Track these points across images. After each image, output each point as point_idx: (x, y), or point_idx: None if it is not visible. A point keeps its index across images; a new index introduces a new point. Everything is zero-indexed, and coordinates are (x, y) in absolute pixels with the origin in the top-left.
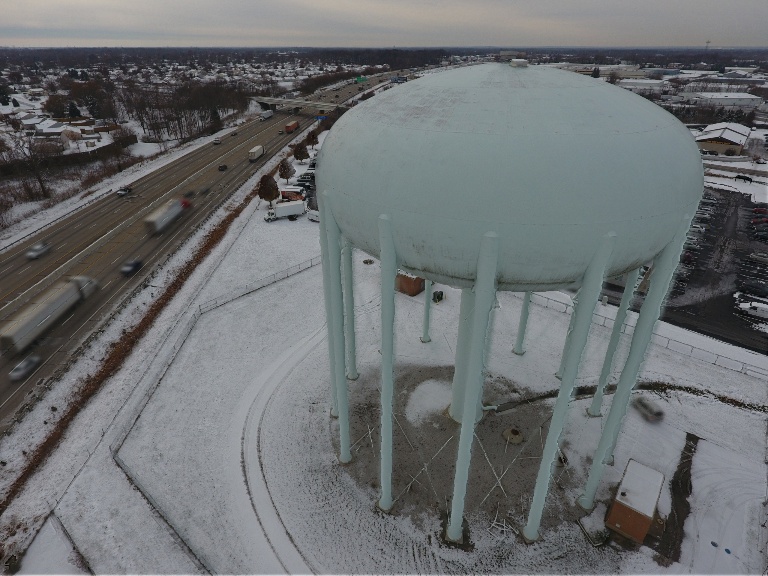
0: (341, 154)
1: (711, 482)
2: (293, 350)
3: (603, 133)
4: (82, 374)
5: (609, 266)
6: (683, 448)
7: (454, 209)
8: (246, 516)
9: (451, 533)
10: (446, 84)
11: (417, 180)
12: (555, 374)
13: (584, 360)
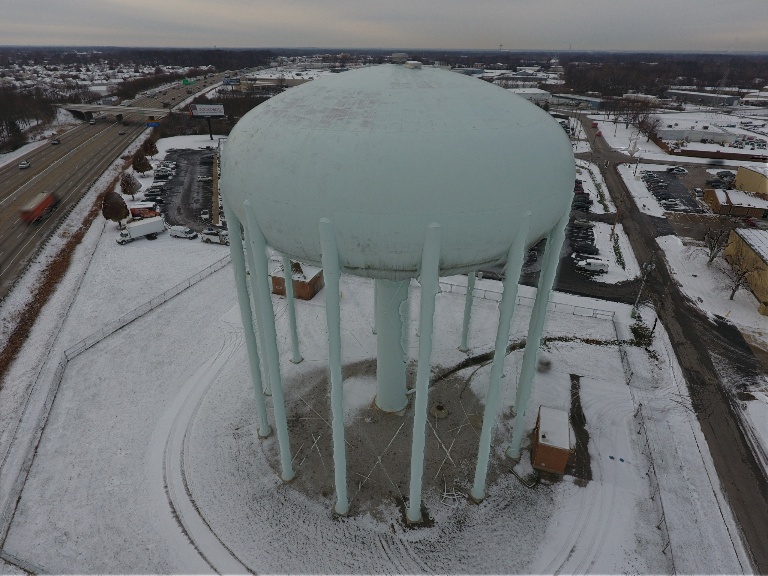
0: (263, 160)
1: (597, 409)
2: (196, 379)
3: (509, 126)
4: None
5: (526, 241)
6: (571, 387)
7: (397, 205)
8: (196, 568)
9: (411, 515)
10: (356, 86)
11: (357, 180)
12: (458, 348)
13: (478, 331)
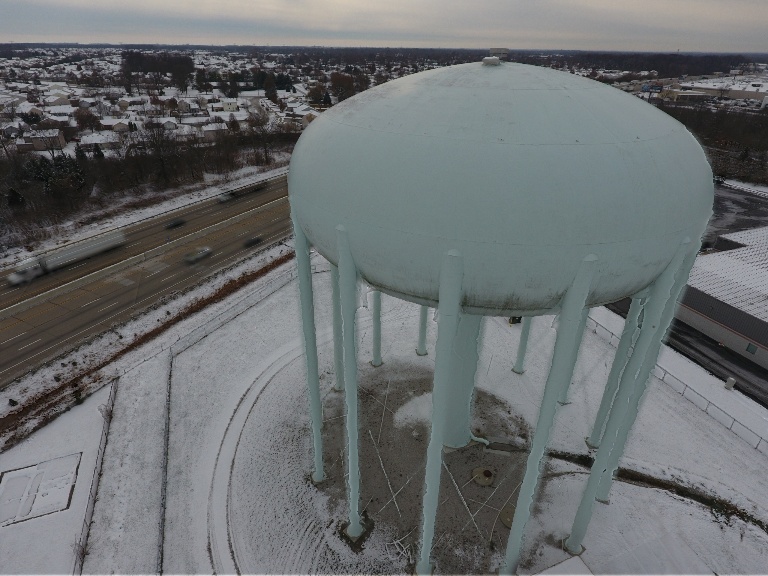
0: None
1: None
2: None
3: (480, 140)
4: (199, 295)
5: (467, 292)
6: None
7: (321, 198)
8: (217, 434)
9: (350, 528)
10: None
11: (306, 166)
12: (586, 438)
13: (639, 438)
